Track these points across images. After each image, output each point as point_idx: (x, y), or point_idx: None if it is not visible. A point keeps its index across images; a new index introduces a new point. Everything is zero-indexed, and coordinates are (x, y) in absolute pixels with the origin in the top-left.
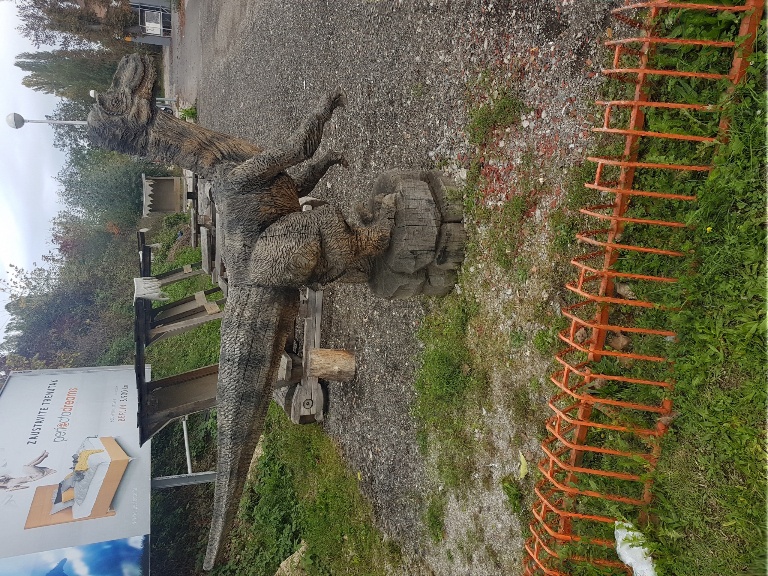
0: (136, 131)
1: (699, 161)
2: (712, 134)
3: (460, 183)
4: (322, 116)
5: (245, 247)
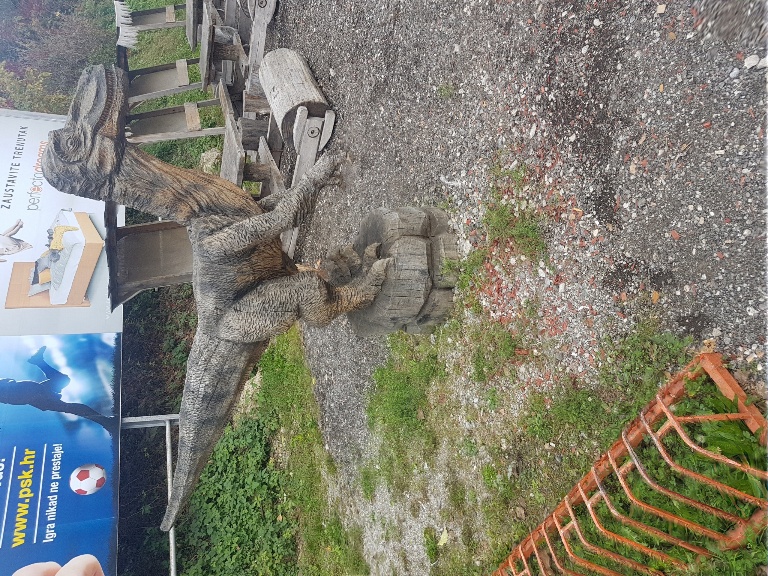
0: (97, 181)
1: (662, 570)
2: (685, 559)
3: (462, 251)
4: (320, 181)
5: (217, 310)
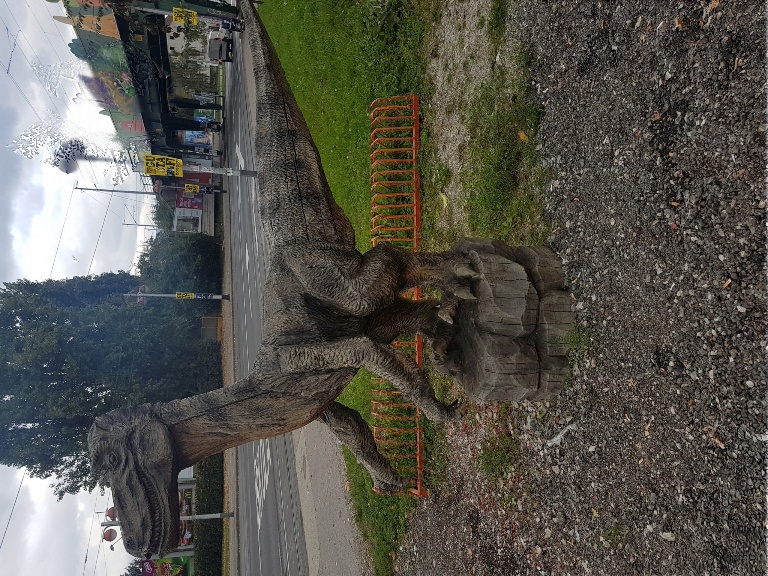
0: None
1: None
2: None
3: None
4: None
5: None
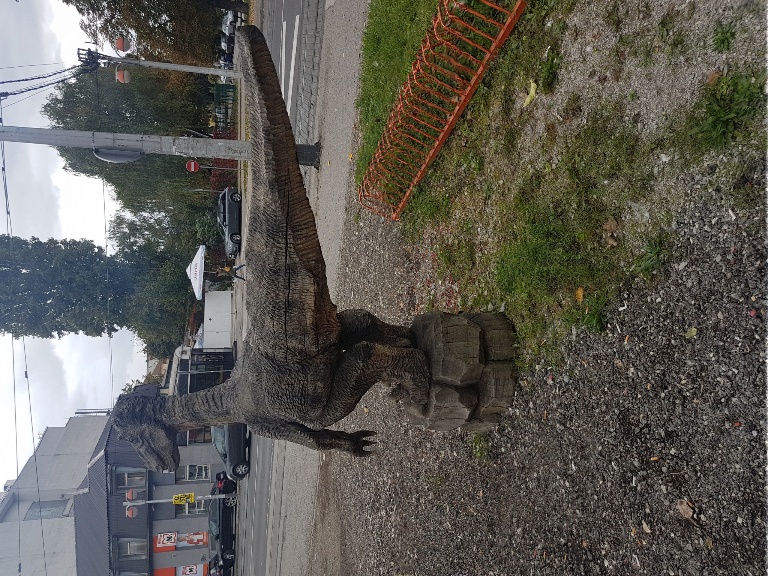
0: None
1: None
2: None
3: None
4: None
5: None
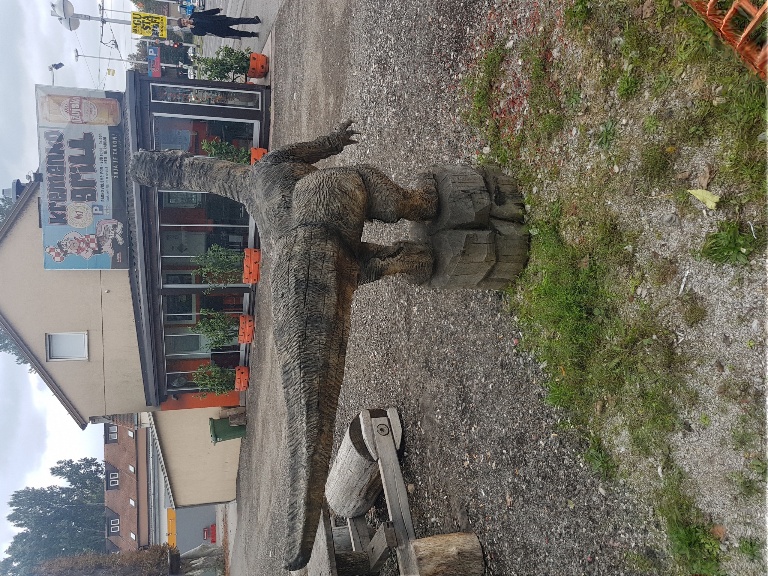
0: None
1: None
2: None
3: None
4: (339, 134)
5: (285, 198)
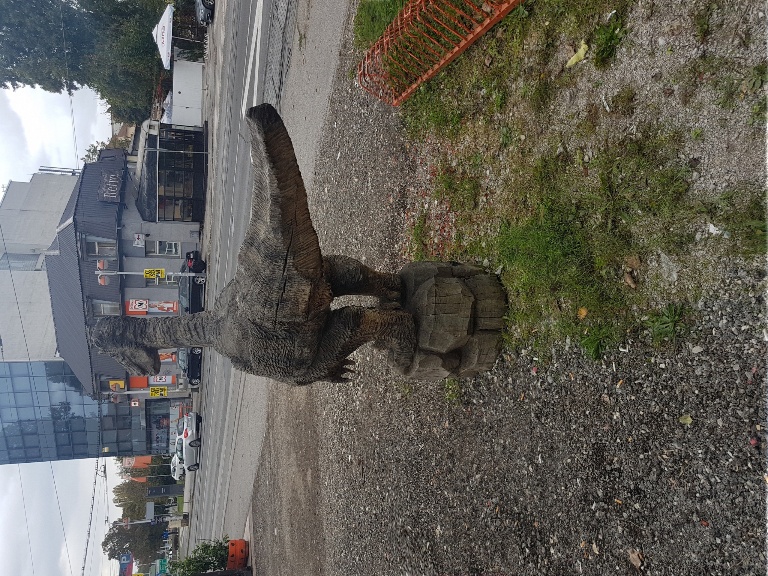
0: None
1: None
2: None
3: None
4: None
5: None
